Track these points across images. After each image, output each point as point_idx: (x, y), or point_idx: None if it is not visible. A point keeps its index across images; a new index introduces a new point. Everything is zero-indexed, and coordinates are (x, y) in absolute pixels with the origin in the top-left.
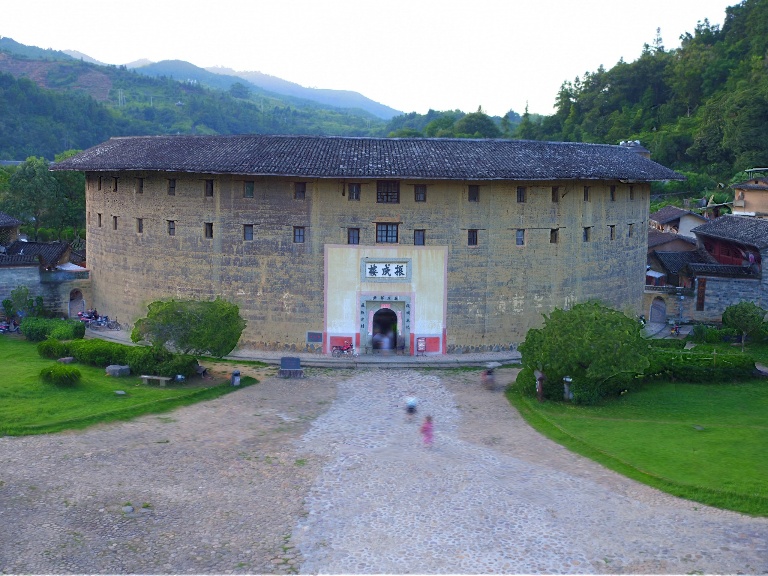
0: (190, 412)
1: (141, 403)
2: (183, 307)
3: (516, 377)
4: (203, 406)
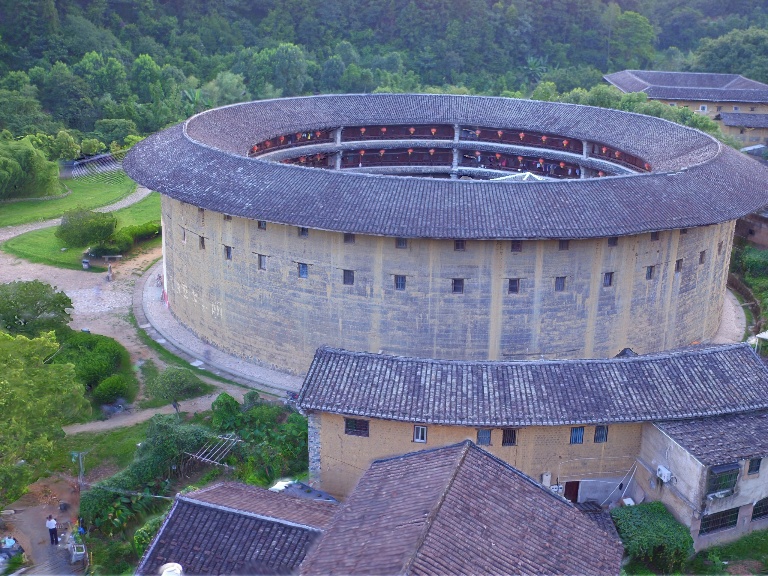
0: (31, 266)
1: (41, 255)
2: (74, 213)
3: (103, 333)
4: (43, 267)
